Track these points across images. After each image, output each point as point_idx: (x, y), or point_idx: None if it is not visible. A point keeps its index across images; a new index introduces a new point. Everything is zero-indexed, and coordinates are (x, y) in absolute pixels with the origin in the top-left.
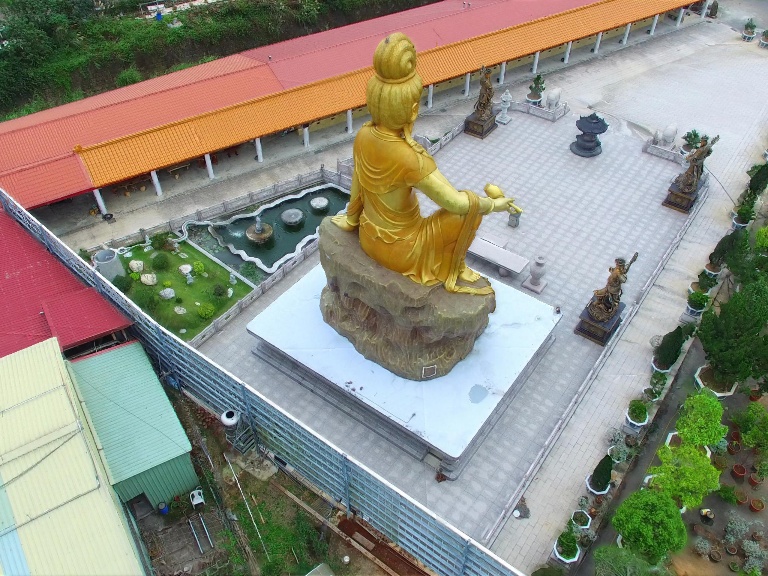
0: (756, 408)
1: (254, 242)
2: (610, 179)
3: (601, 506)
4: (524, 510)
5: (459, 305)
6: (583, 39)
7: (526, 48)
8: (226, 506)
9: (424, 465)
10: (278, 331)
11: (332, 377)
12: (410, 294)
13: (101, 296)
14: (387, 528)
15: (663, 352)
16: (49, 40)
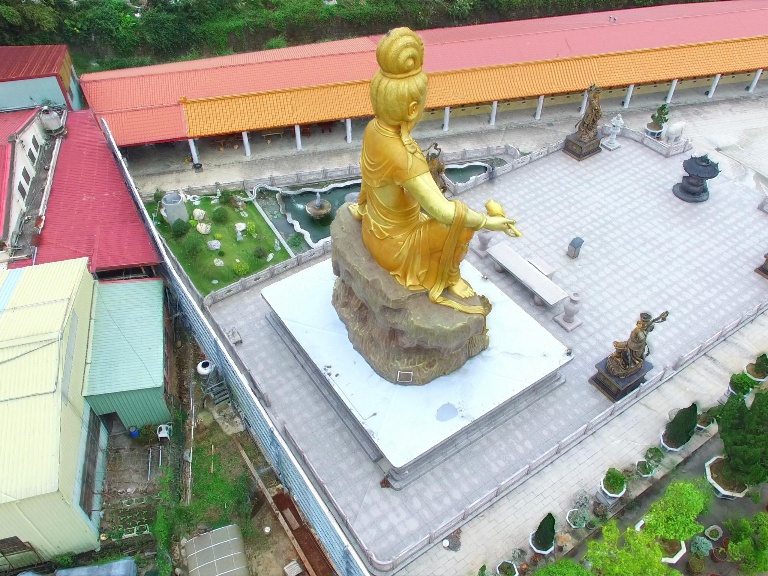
0: (763, 520)
1: (310, 216)
2: (704, 230)
3: (536, 565)
4: (455, 542)
5: (436, 317)
6: (740, 74)
7: (661, 74)
8: (187, 447)
9: (375, 466)
10: (287, 302)
11: (315, 357)
12: (388, 293)
13: (146, 232)
14: (308, 513)
15: (672, 427)
16: (215, 1)
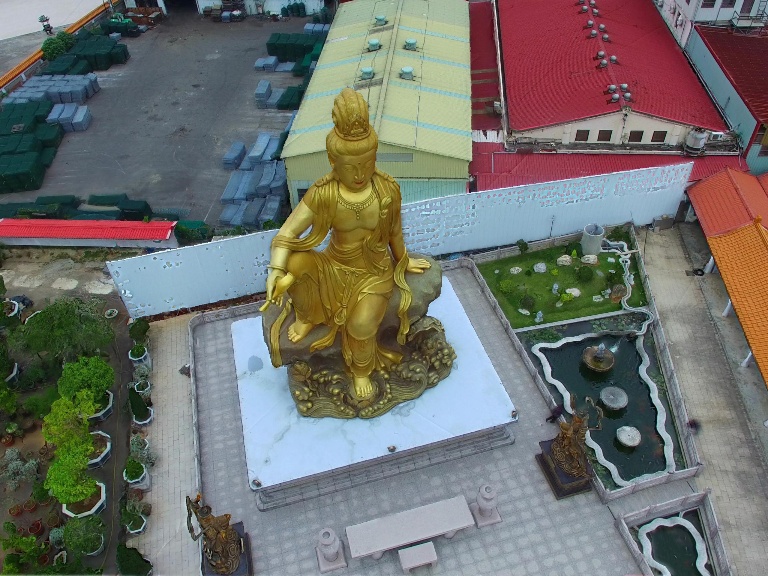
0: None
1: None
2: None
3: None
4: (185, 370)
5: None
6: None
7: None
8: None
9: None
10: None
11: None
12: None
13: None
14: (243, 286)
15: None
16: None
